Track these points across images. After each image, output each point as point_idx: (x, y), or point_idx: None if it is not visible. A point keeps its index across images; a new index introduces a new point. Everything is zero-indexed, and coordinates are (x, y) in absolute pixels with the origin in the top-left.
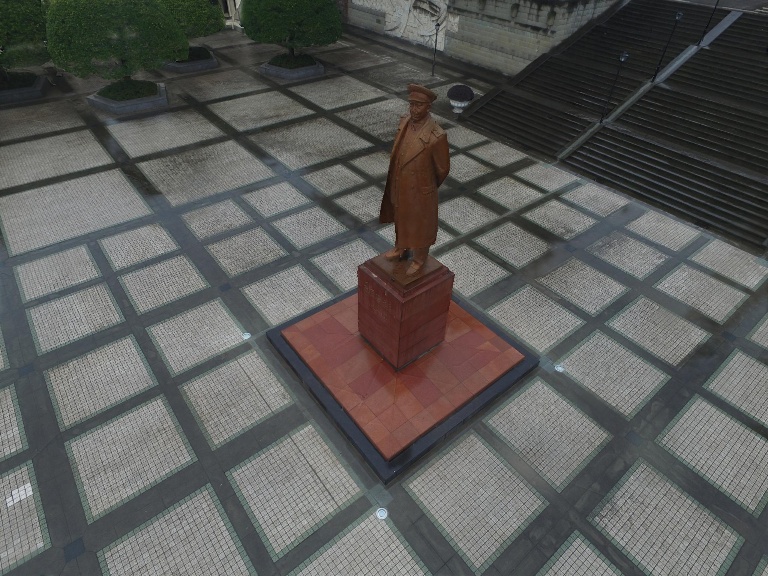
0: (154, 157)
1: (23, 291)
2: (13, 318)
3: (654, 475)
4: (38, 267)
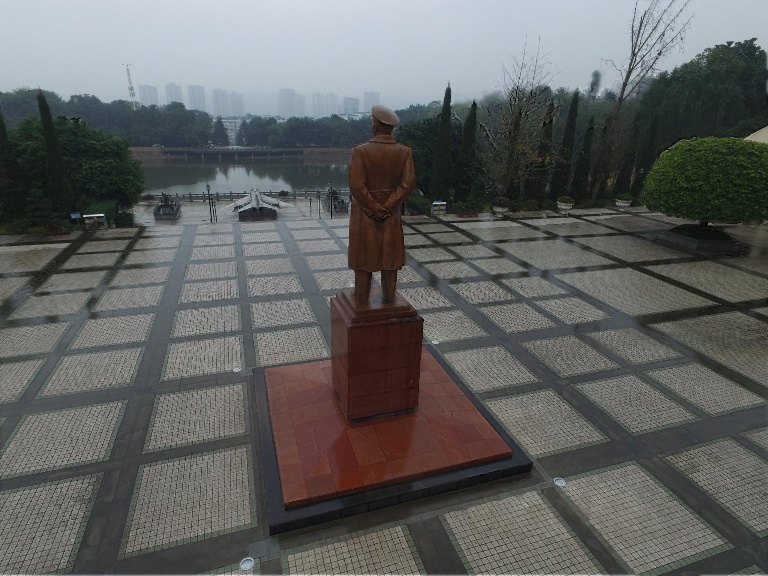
0: (765, 320)
1: (511, 279)
2: (484, 278)
3: (45, 568)
4: (538, 281)
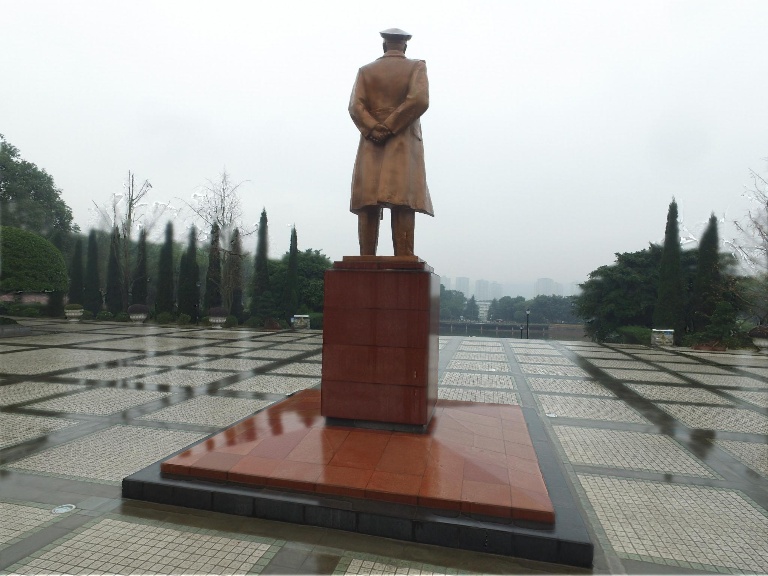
0: None
1: (742, 391)
2: (691, 386)
3: None
4: None
